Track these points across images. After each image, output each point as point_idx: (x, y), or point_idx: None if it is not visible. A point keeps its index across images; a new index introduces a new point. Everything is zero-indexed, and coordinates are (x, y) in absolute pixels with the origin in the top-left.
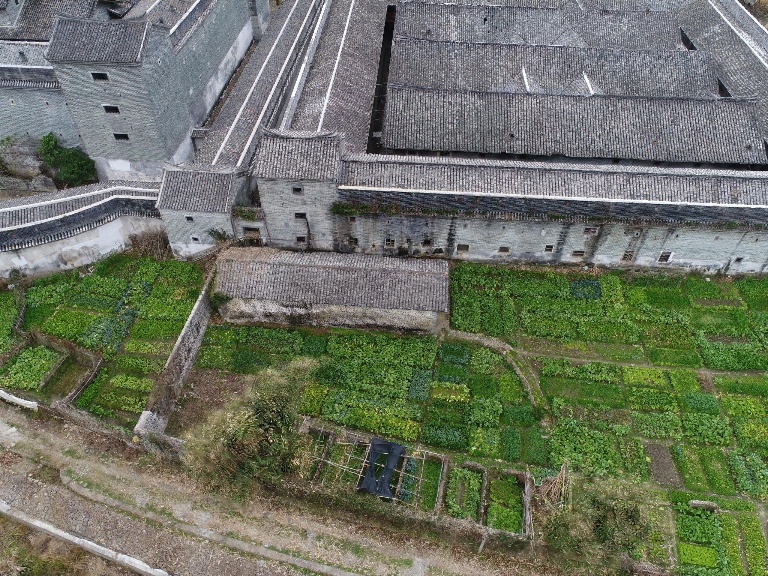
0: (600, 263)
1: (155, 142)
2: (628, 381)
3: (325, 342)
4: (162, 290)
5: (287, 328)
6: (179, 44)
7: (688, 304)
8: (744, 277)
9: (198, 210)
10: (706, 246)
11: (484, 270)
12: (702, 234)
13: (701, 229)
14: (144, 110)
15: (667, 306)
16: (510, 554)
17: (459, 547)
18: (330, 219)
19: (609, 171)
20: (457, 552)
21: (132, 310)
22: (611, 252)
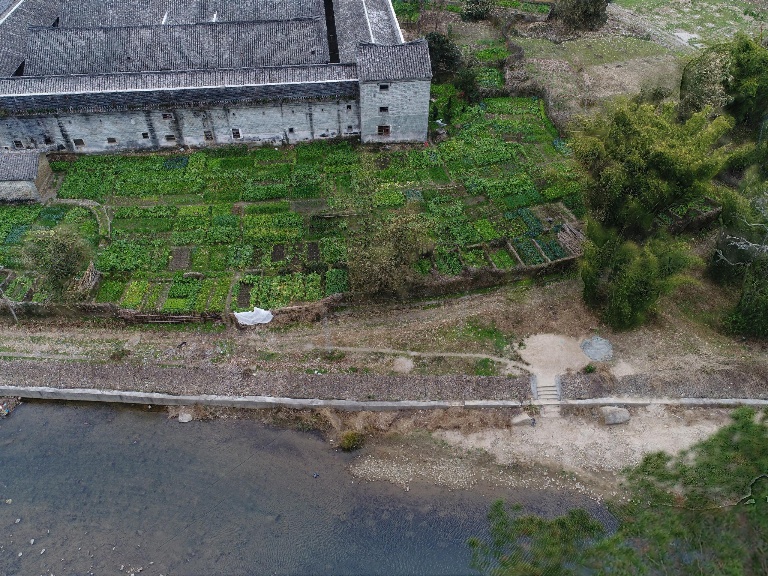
0: (192, 144)
1: None
2: (179, 215)
3: None
4: None
5: None
6: None
7: (252, 165)
8: (299, 143)
9: None
10: (260, 121)
11: (100, 159)
12: (251, 111)
13: (246, 106)
14: None
15: (235, 168)
16: (40, 320)
17: (4, 322)
18: None
19: (177, 71)
20: (0, 324)
21: None
22: (194, 134)
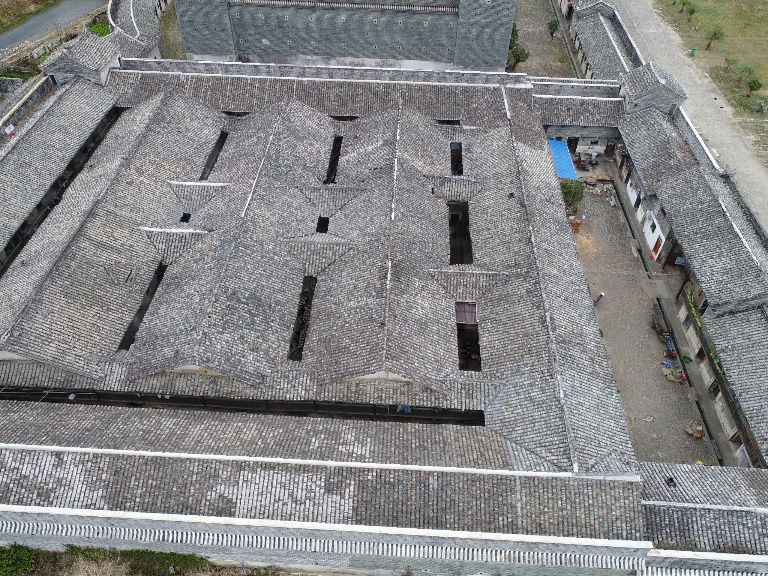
0: None
1: None
2: None
3: None
4: None
5: None
6: (256, 0)
7: None
8: None
9: None
10: None
11: None
12: None
13: None
14: None
15: None
16: None
17: None
18: None
19: None
20: None
21: None
22: None
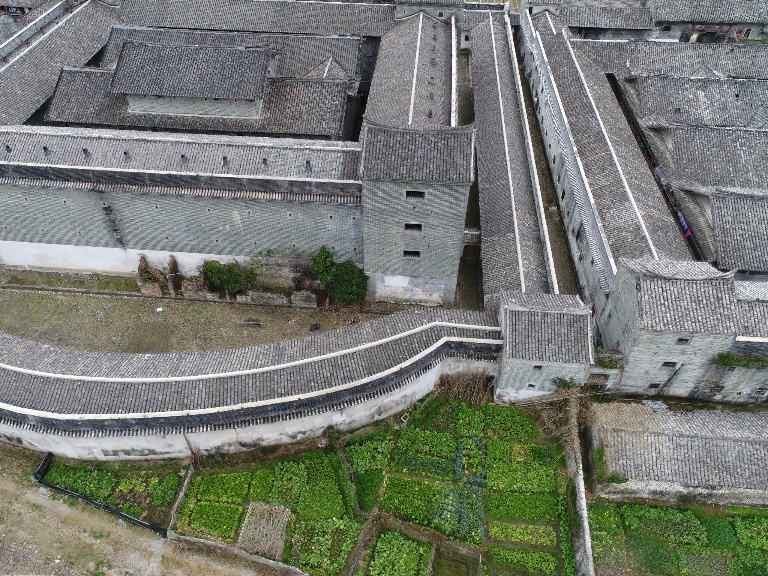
0: None
1: (450, 259)
2: None
3: (732, 528)
4: (500, 449)
5: (675, 506)
6: None
7: None
8: None
9: (558, 361)
10: None
11: None
12: None
13: None
14: (452, 228)
15: None
16: None
17: None
18: (704, 368)
19: None
20: None
21: (480, 479)
22: None
